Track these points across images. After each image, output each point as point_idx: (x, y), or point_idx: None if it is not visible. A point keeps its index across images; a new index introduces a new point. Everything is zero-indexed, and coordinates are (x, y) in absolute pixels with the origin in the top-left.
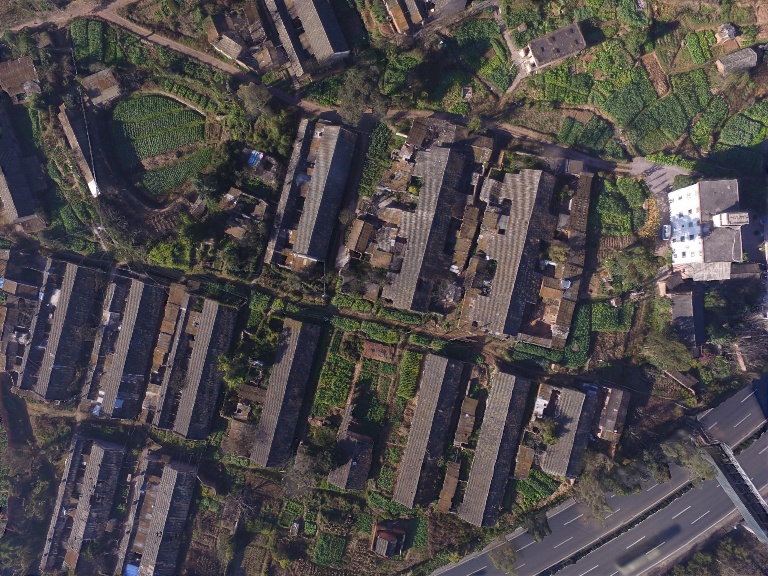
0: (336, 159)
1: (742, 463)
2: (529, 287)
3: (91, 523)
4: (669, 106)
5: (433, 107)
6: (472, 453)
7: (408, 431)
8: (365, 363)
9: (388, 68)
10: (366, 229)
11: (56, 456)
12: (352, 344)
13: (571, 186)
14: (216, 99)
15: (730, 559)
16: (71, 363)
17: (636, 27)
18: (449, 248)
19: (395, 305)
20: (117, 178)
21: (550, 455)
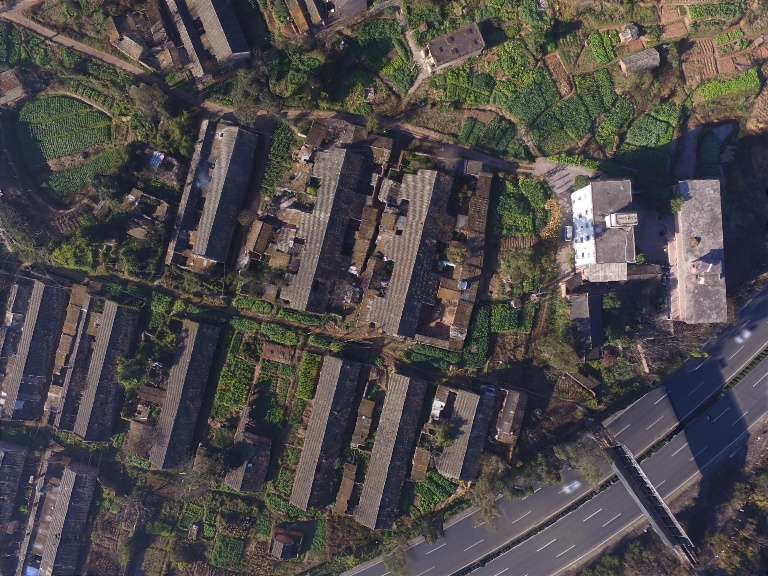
0: (235, 160)
1: (654, 465)
2: (426, 288)
3: None
4: (572, 106)
5: (336, 107)
6: (369, 455)
7: (306, 433)
8: (264, 364)
9: (291, 68)
10: (265, 230)
11: None
12: (252, 345)
13: (471, 187)
14: (118, 100)
15: (637, 562)
16: None
17: (538, 27)
18: (349, 249)
19: (292, 306)
20: (23, 179)
21: (446, 457)
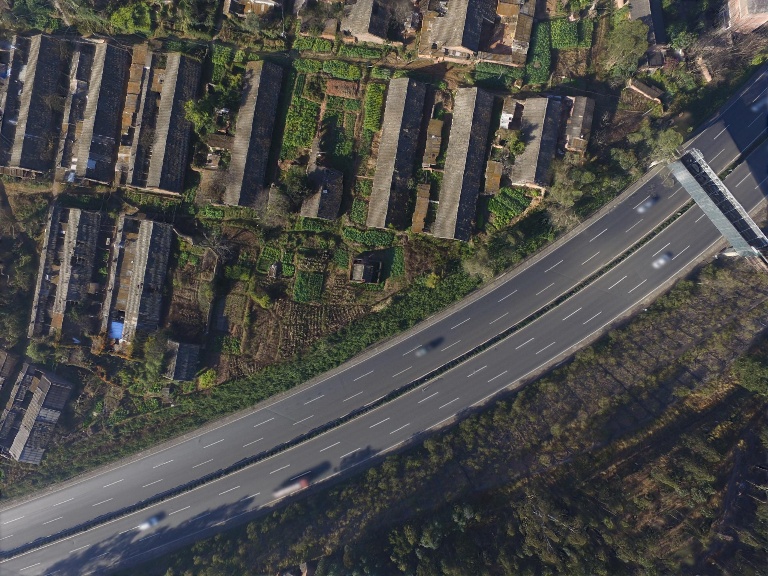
0: None
1: None
2: (485, 3)
3: (73, 284)
4: None
5: None
6: (441, 176)
7: None
8: (329, 101)
9: None
10: None
11: (36, 230)
12: (315, 84)
13: None
14: None
15: (712, 281)
16: (43, 134)
17: None
18: None
19: (353, 33)
20: None
21: (518, 165)
